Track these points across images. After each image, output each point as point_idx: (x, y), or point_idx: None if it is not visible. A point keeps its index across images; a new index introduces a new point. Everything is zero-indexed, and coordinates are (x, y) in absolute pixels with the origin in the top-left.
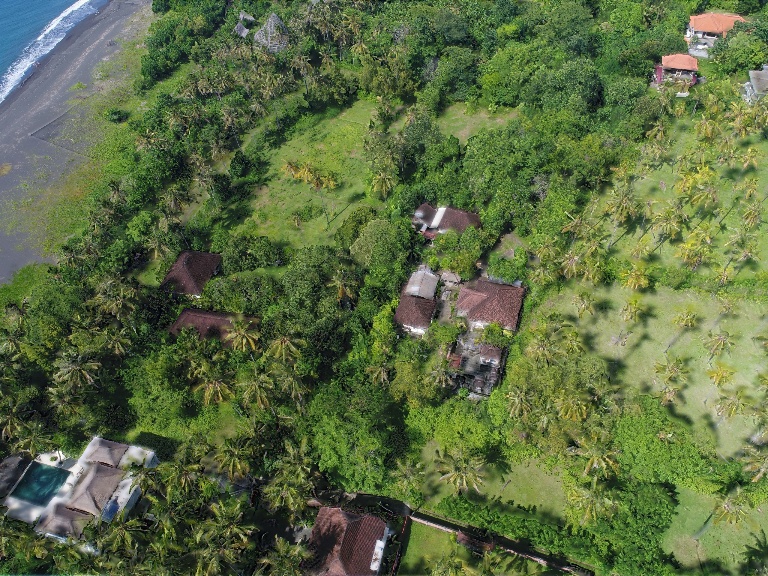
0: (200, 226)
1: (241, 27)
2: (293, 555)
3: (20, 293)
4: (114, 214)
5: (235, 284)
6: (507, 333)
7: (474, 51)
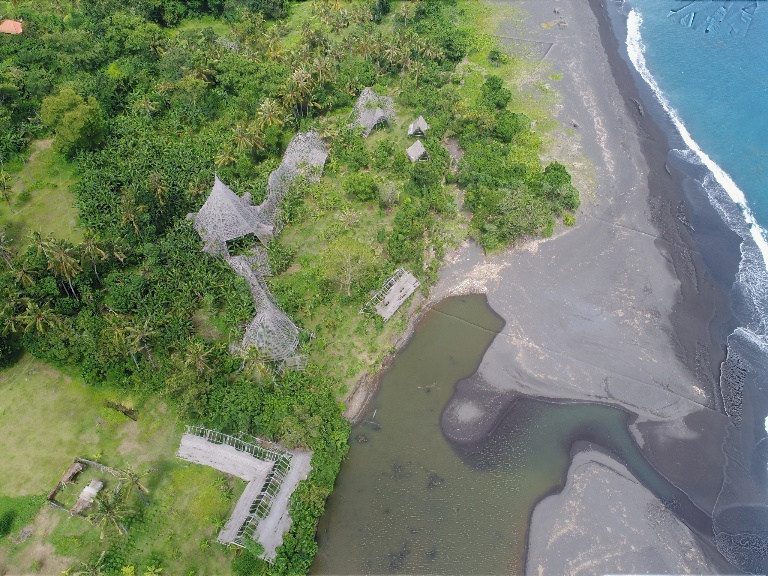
0: None
1: None
2: None
3: None
4: None
5: None
6: None
7: None
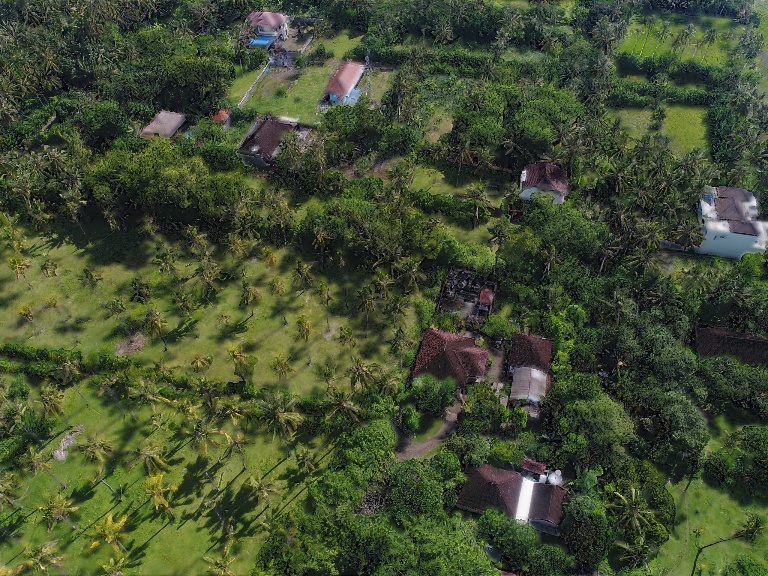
0: None
1: None
2: (572, 137)
3: None
4: None
5: (756, 380)
6: (434, 327)
7: None
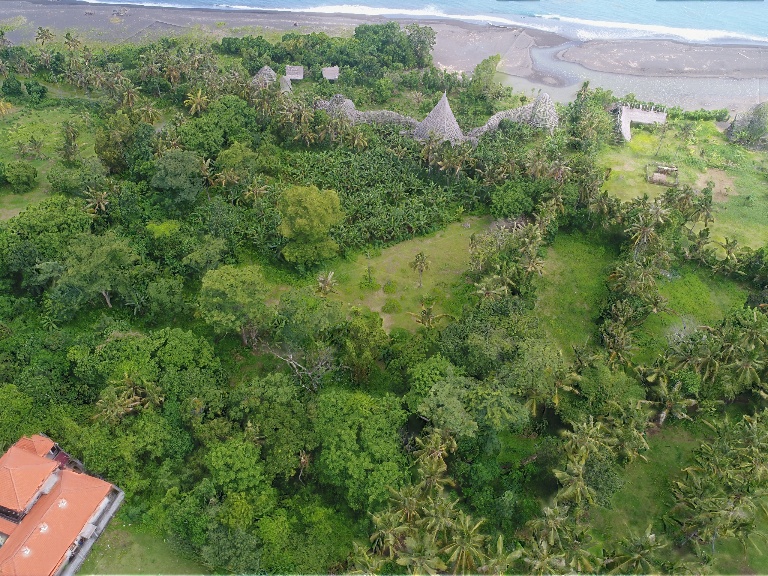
0: None
1: (298, 71)
2: None
3: None
4: None
5: None
6: None
7: (189, 225)
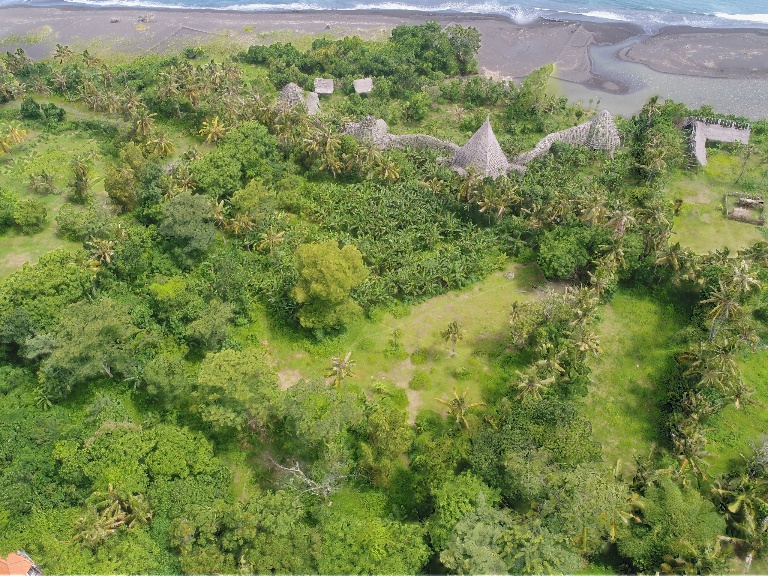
0: (8, 112)
1: (327, 84)
2: None
3: (2, 62)
4: (9, 64)
5: None
6: None
7: (201, 276)
